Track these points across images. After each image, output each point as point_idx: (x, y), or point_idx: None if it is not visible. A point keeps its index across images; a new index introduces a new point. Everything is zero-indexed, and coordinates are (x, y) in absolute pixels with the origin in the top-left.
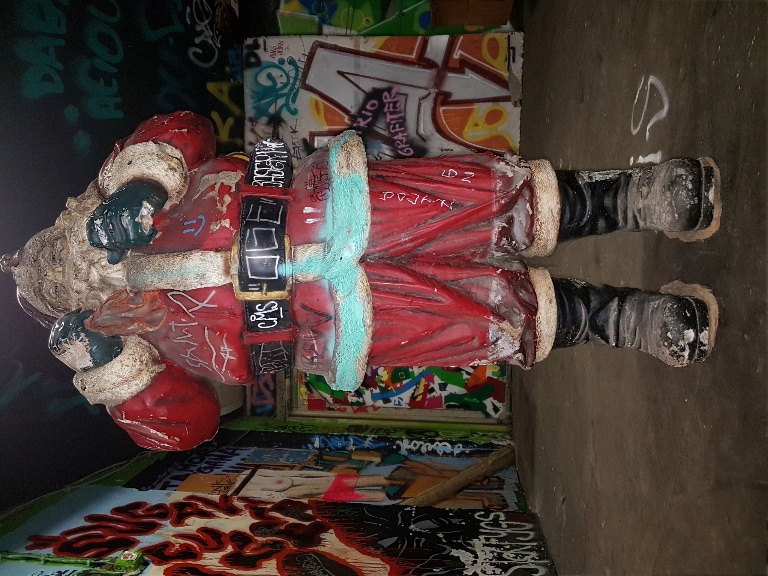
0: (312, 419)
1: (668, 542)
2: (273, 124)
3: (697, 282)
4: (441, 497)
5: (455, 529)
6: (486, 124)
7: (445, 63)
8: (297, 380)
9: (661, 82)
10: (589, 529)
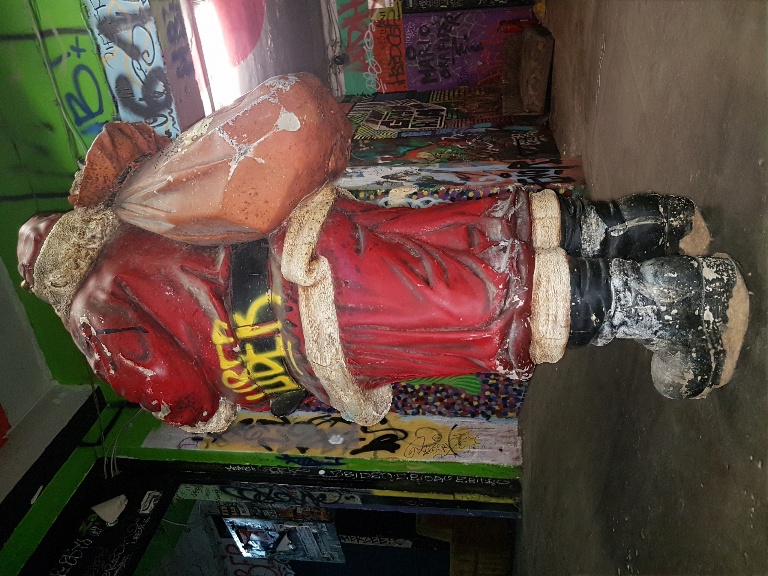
0: None
1: None
2: None
3: None
4: None
5: None
6: None
7: None
8: None
9: None
10: None
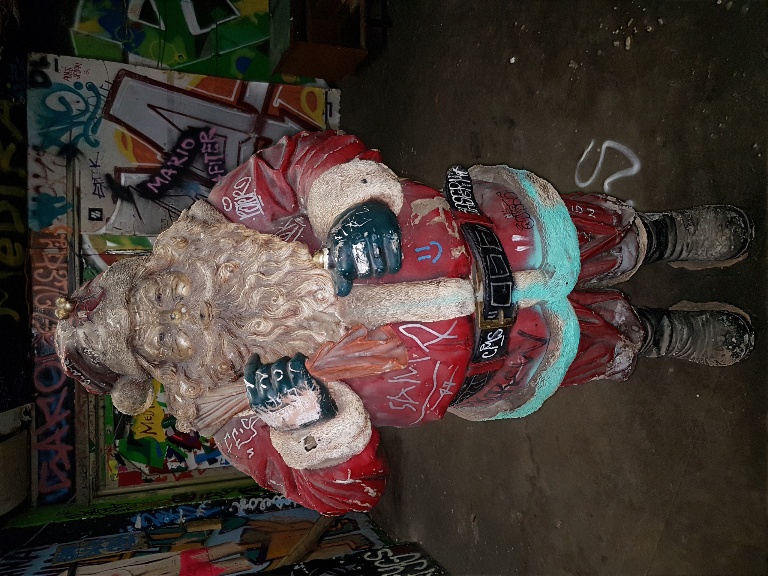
0: (125, 496)
1: (681, 516)
2: (67, 155)
3: (707, 301)
4: (307, 550)
5: (355, 575)
6: None
7: (264, 110)
8: (104, 452)
9: (627, 146)
10: (529, 535)
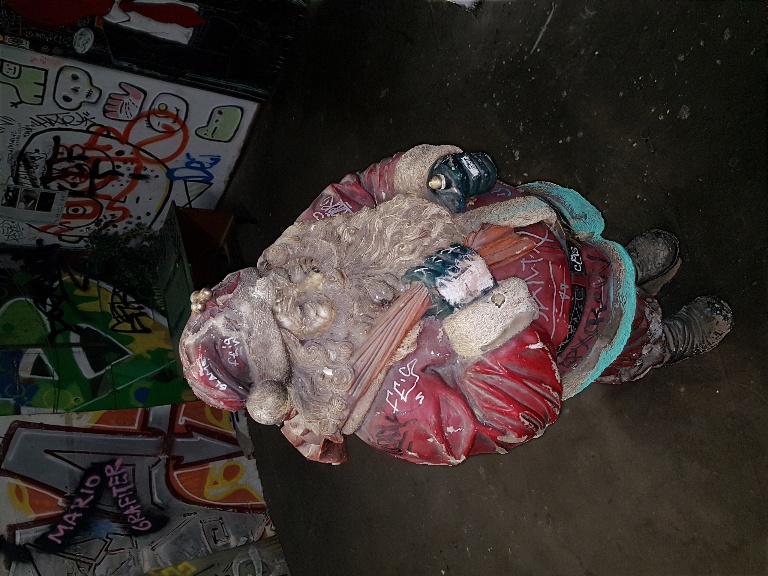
0: None
1: None
2: None
3: None
4: None
5: None
6: (225, 480)
7: (171, 430)
8: None
9: None
10: None
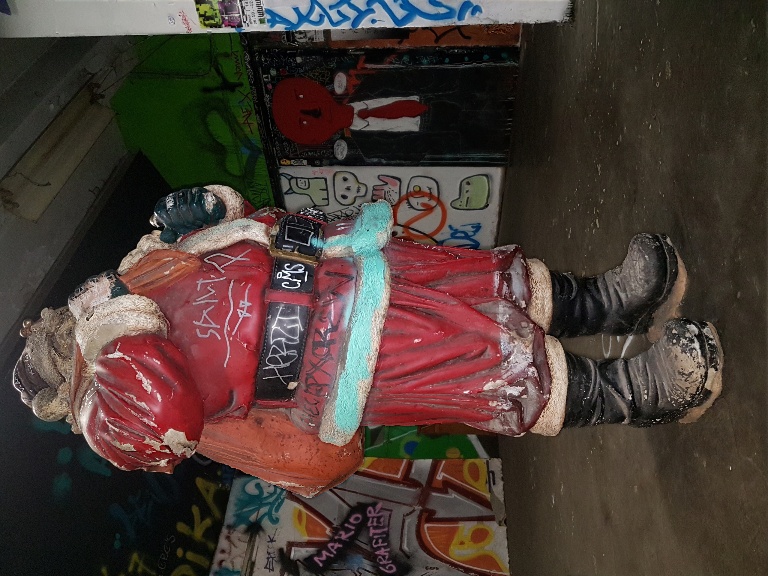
0: None
1: None
2: (251, 532)
3: None
4: None
5: None
6: (472, 542)
7: (429, 483)
8: None
9: None
10: None
